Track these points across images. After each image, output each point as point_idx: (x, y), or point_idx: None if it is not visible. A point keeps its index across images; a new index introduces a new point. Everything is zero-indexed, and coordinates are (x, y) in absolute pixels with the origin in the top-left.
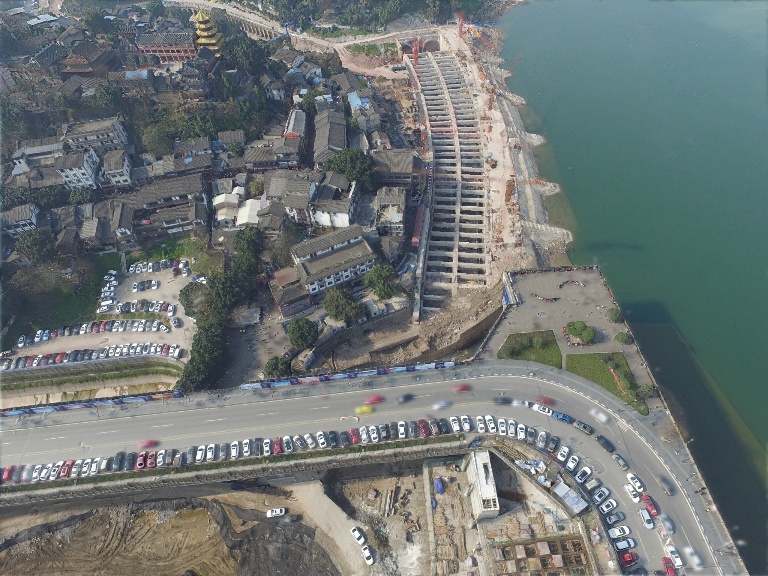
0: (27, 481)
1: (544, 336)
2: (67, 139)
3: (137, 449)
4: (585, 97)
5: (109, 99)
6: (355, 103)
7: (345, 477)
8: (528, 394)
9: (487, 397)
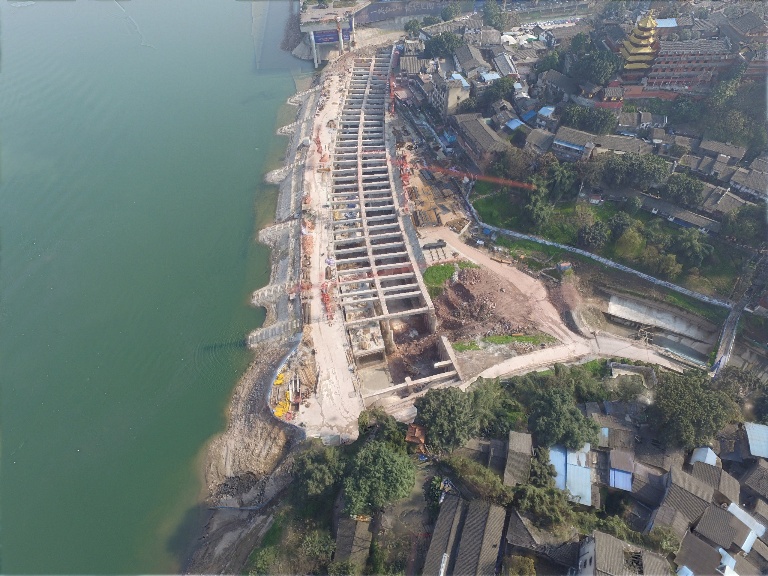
0: None
1: (338, 6)
2: None
3: None
4: (177, 240)
5: None
6: (458, 76)
7: None
8: None
9: None
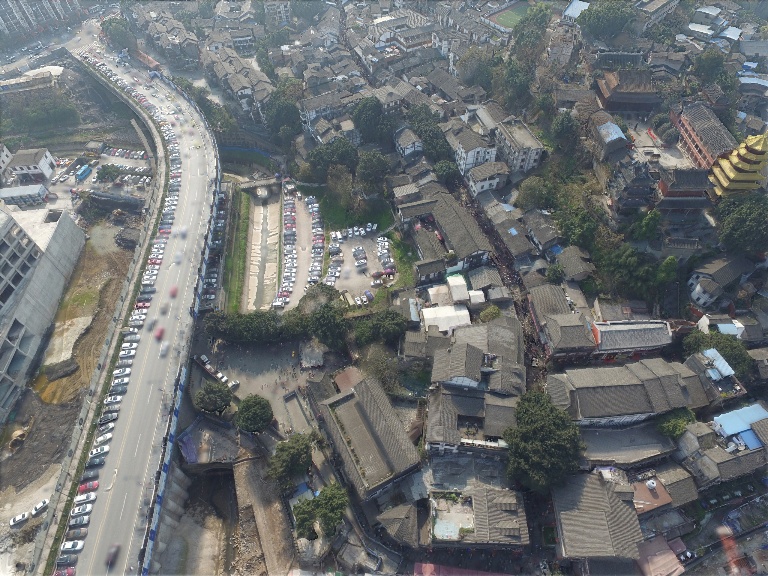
0: None
1: None
2: None
3: None
4: None
5: (556, 129)
6: (728, 421)
7: None
8: None
9: None
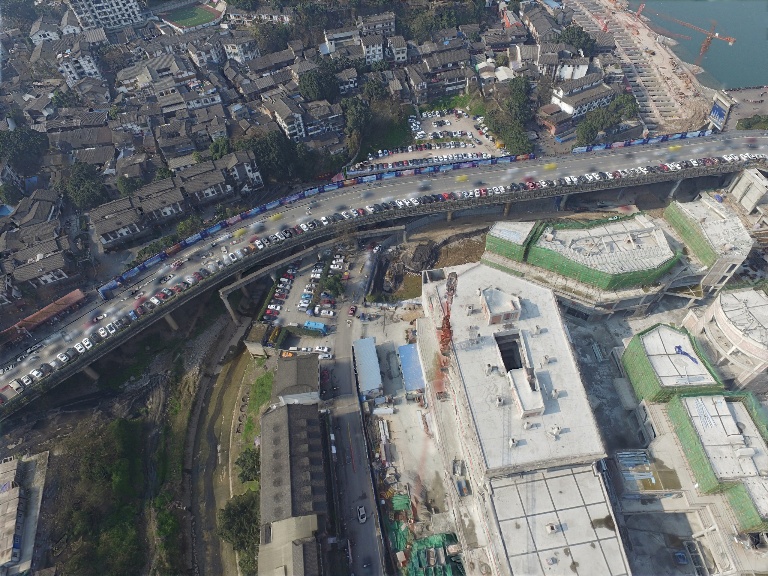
0: (461, 198)
1: None
2: (362, 27)
3: (522, 182)
4: (697, 14)
5: None
6: (553, 4)
7: (642, 209)
8: (767, 144)
9: (740, 147)
